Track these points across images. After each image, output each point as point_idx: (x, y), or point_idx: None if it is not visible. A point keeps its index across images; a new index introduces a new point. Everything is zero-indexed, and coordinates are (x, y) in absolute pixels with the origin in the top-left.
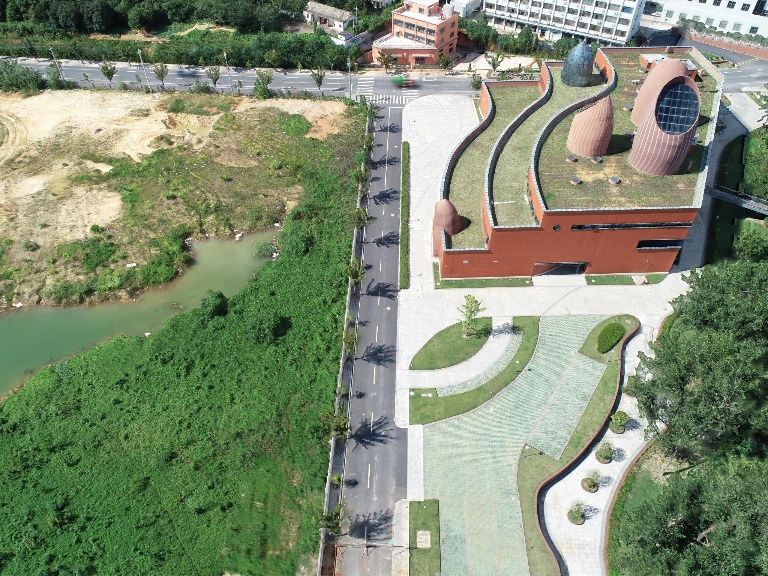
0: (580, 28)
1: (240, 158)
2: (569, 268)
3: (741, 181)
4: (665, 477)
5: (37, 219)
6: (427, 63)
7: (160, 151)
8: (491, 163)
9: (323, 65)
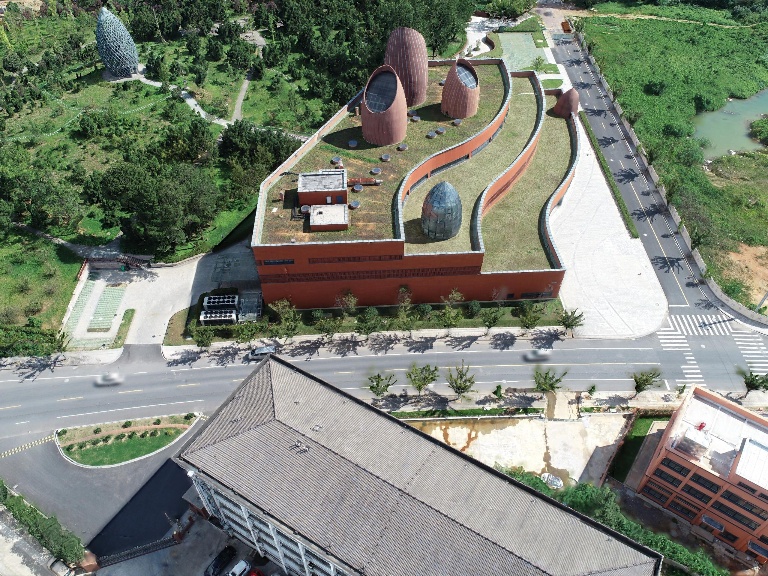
0: None
1: None
2: None
3: None
4: None
5: None
6: None
7: None
8: None
9: None
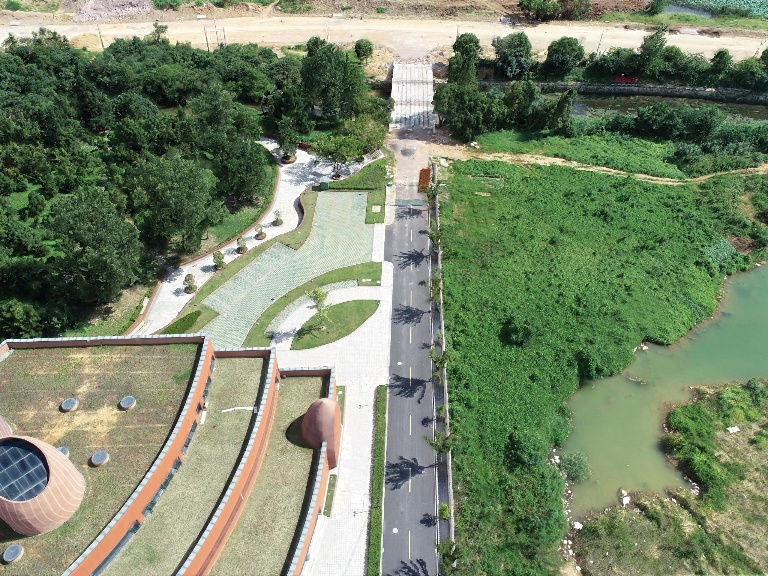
0: None
1: None
2: None
3: None
4: None
5: None
6: None
7: None
8: None
9: None
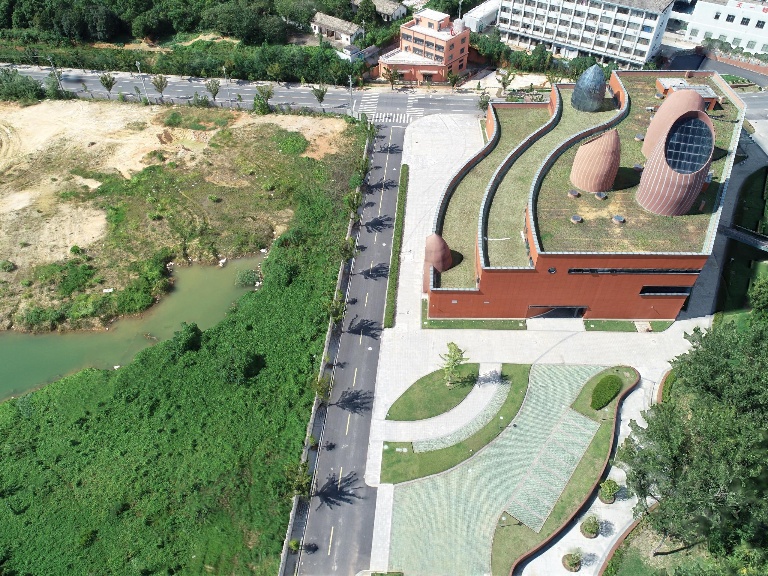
0: (597, 46)
1: (232, 177)
2: (567, 311)
3: (761, 218)
4: (656, 558)
5: (19, 237)
6: (435, 80)
7: (151, 168)
8: (488, 194)
9: (327, 80)
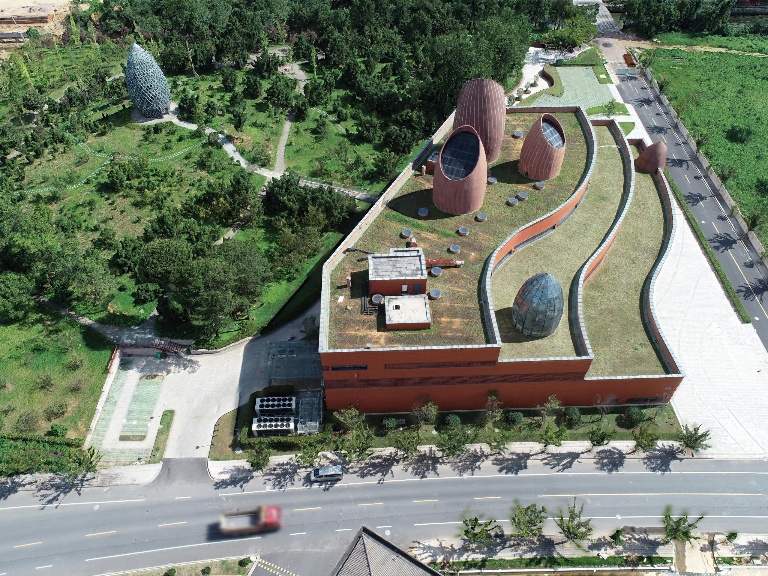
0: None
1: None
2: None
3: (329, 251)
4: None
5: None
6: None
7: None
8: None
9: None
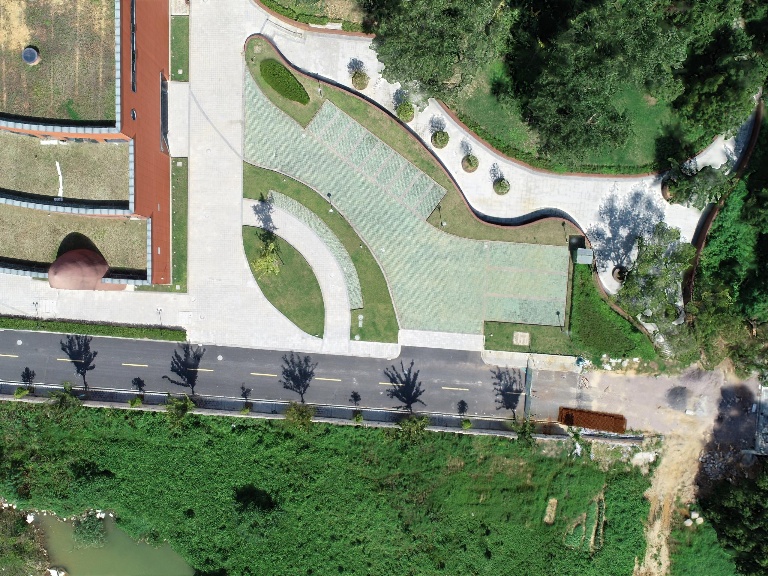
0: None
1: None
2: None
3: None
4: None
5: None
6: None
7: None
8: None
9: None
